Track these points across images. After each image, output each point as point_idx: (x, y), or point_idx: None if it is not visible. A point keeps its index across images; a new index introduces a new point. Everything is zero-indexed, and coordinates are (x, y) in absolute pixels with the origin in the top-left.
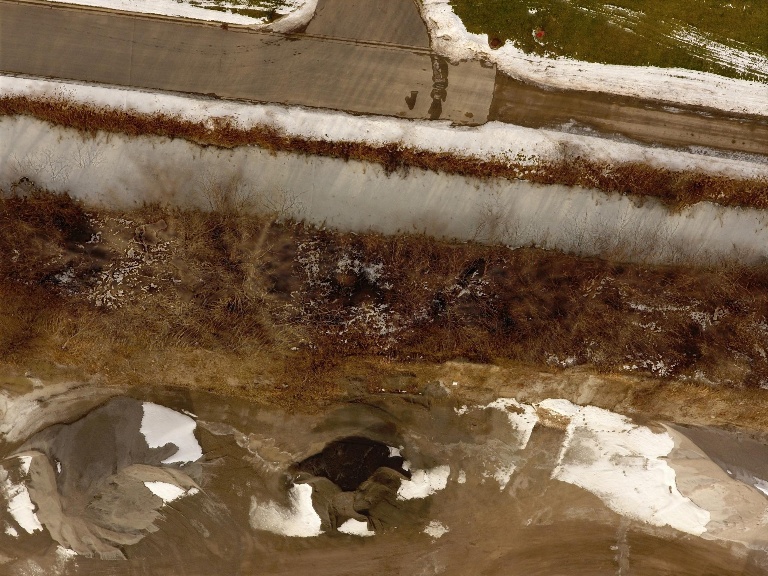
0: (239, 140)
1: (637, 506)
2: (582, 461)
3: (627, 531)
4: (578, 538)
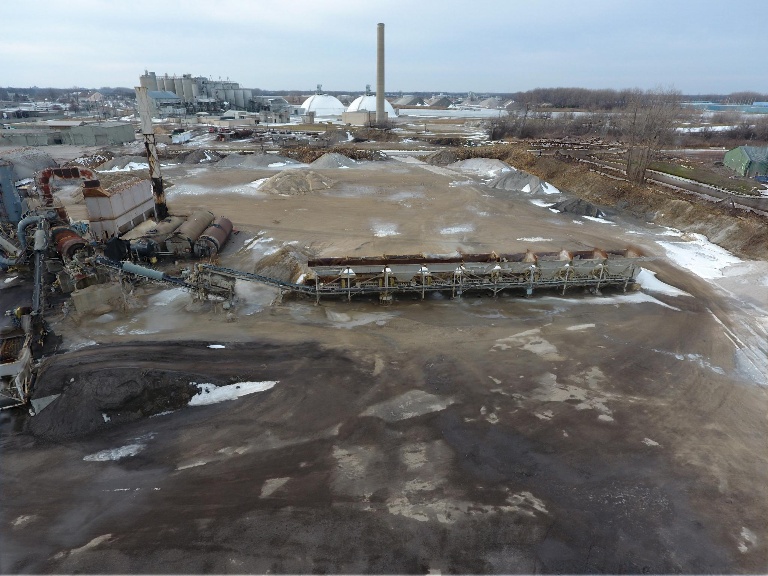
0: (681, 195)
1: (683, 260)
2: (679, 246)
3: (661, 259)
4: (631, 247)
